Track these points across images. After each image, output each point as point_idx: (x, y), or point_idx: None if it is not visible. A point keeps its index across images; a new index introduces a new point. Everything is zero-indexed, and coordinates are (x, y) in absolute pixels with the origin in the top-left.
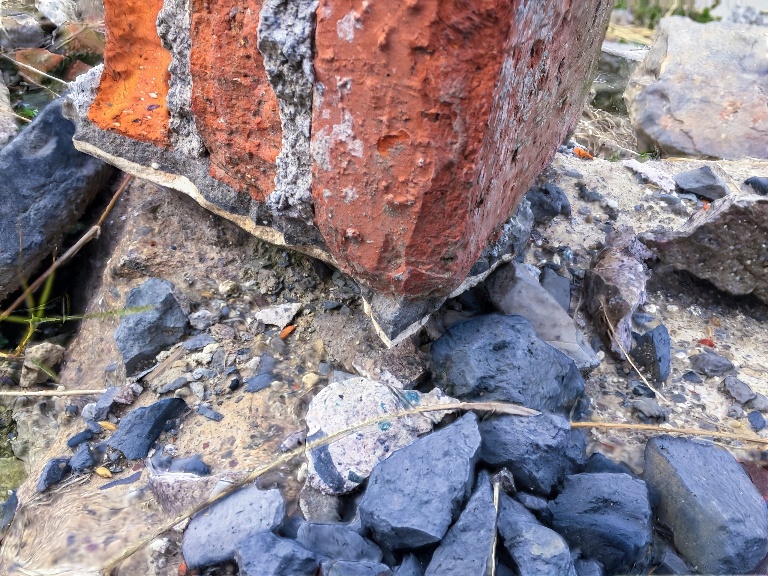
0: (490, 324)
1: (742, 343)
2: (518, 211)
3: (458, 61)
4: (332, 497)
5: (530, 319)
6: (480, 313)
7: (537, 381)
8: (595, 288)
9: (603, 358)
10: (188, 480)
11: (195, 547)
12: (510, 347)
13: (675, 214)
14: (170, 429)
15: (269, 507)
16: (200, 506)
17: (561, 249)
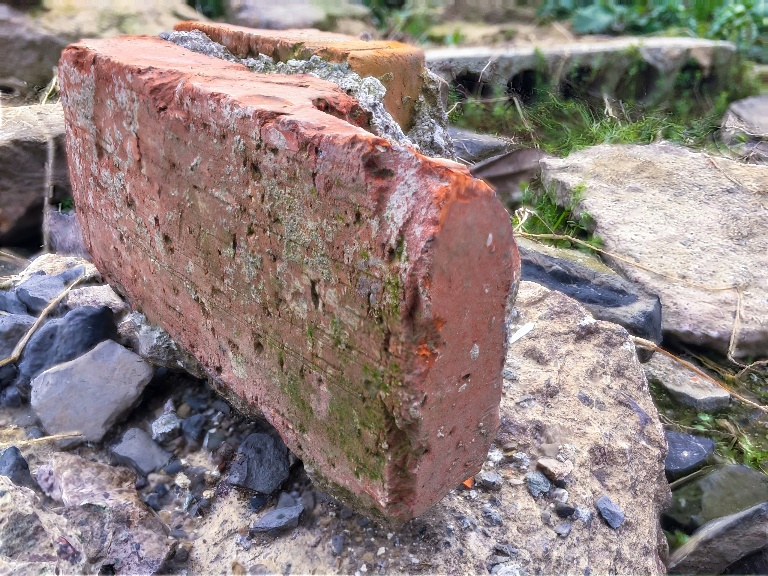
0: None
1: None
2: (156, 329)
3: None
4: None
5: None
6: None
7: None
8: None
9: None
10: None
11: None
12: None
13: None
14: None
15: None
16: None
17: (200, 500)
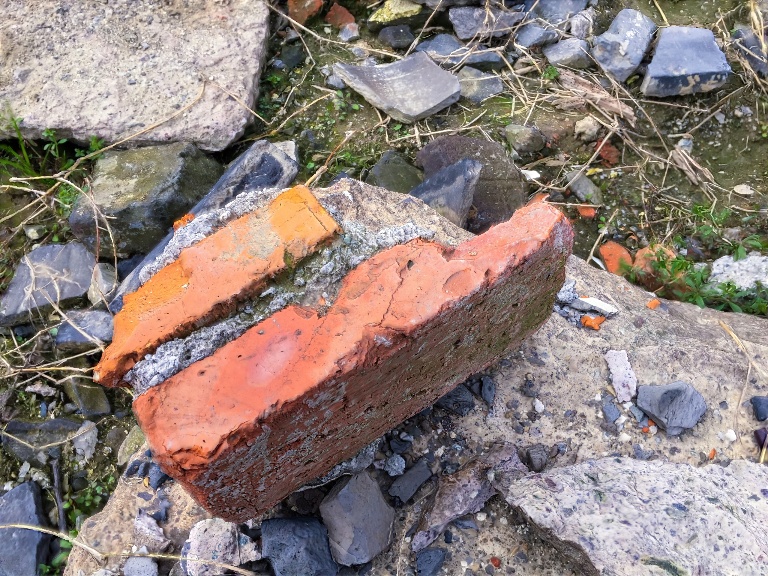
0: (286, 530)
1: (532, 571)
2: (359, 453)
3: (187, 489)
4: (185, 574)
5: (332, 523)
6: (324, 496)
7: (293, 571)
8: (433, 494)
9: (409, 542)
10: (144, 531)
11: (126, 569)
12: (288, 548)
13: (602, 429)
14: (171, 480)
15: (151, 571)
16: (132, 554)
17: (456, 440)
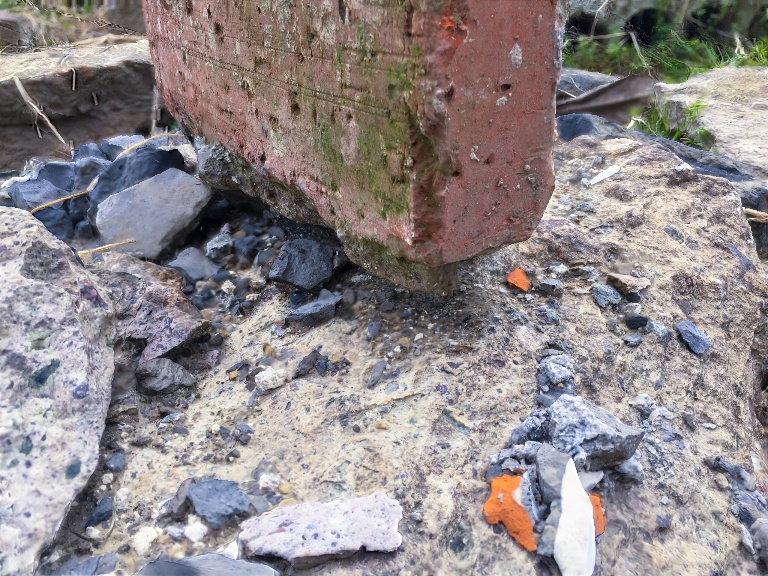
0: None
1: None
2: None
3: None
4: None
5: None
6: None
7: None
8: None
9: None
10: None
11: None
12: None
13: None
14: None
15: None
16: None
17: None
